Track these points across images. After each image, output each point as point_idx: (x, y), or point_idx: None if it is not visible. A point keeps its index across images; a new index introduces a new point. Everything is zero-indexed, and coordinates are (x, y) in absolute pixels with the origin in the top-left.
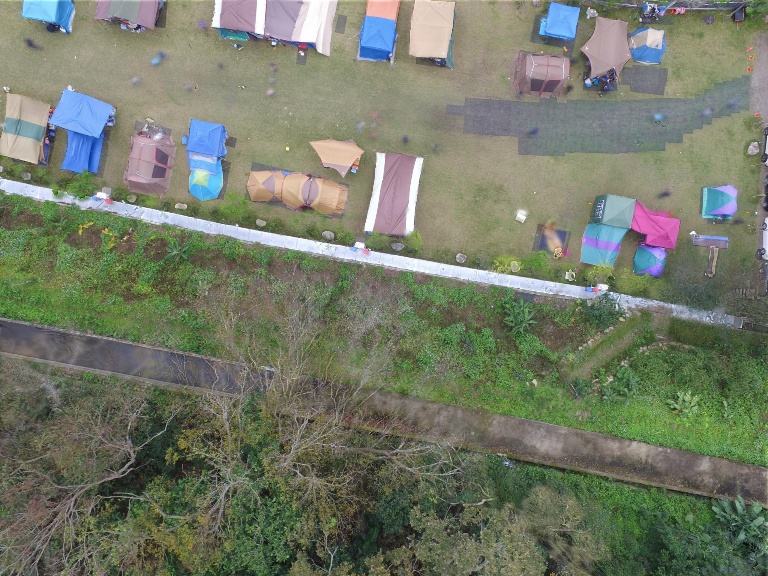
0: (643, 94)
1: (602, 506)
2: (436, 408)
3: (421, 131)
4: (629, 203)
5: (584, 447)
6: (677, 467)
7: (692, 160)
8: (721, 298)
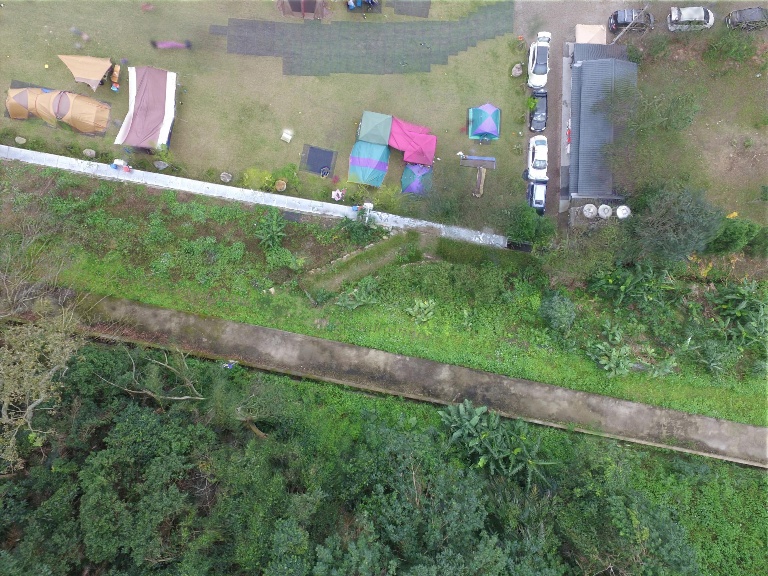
0: (407, 16)
1: (327, 410)
2: (167, 314)
3: (184, 50)
4: (384, 119)
5: (320, 355)
6: (416, 375)
7: (457, 81)
8: (490, 219)
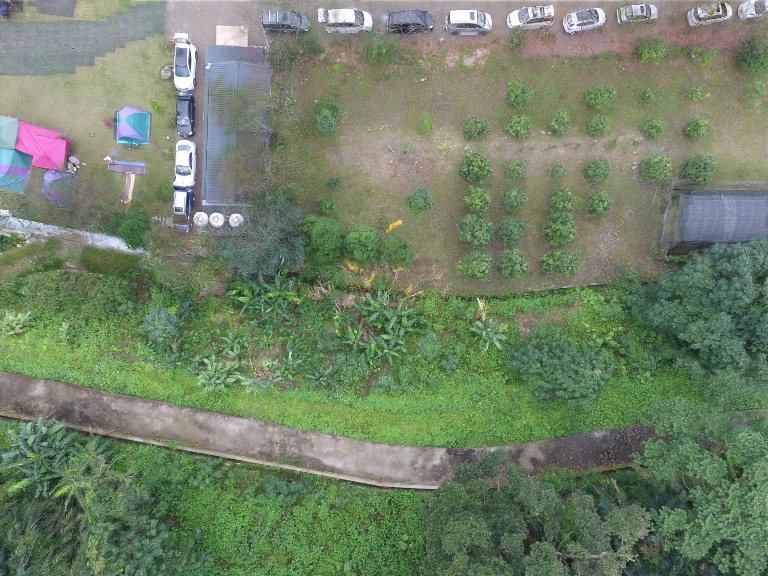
0: (51, 16)
1: None
2: None
3: None
4: (7, 122)
5: None
6: (8, 391)
7: (104, 84)
8: None
